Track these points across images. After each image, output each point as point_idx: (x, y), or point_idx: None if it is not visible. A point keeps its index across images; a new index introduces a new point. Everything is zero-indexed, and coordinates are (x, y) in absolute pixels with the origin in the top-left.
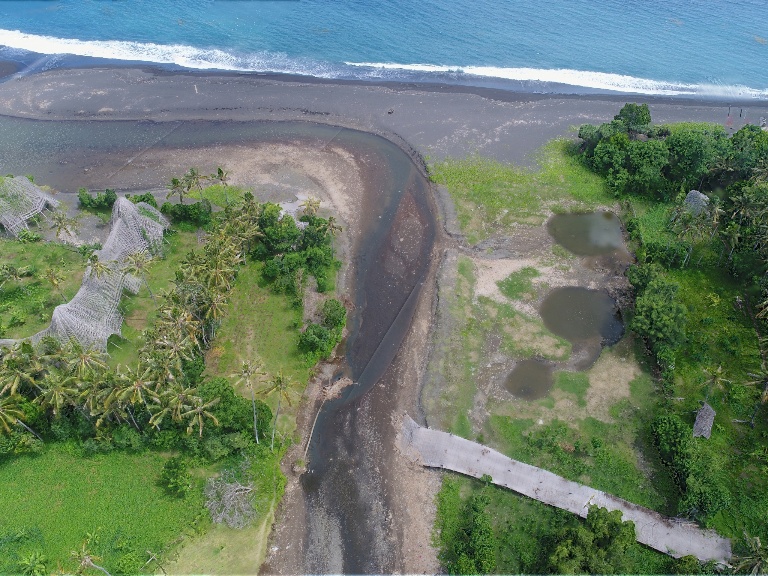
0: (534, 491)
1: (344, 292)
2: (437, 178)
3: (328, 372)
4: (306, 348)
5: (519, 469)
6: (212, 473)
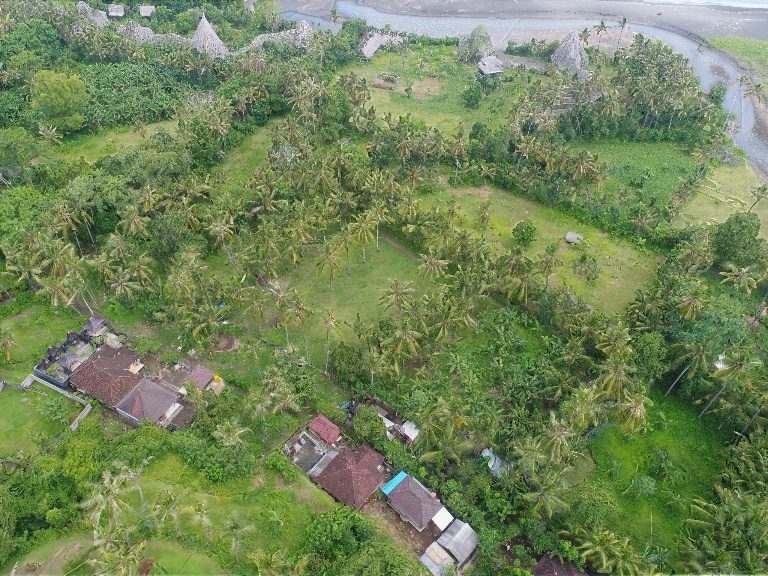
0: None
1: None
2: (716, 45)
3: None
4: None
5: None
6: (702, 150)
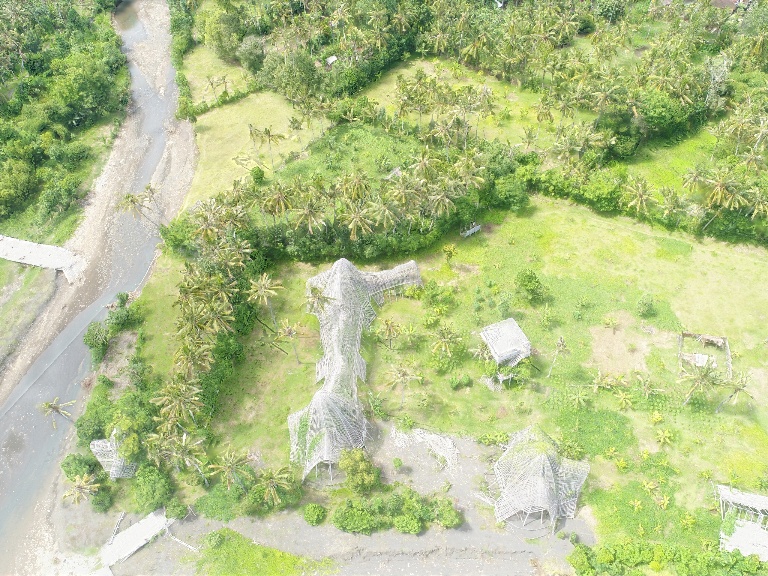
0: (4, 240)
1: (87, 398)
2: None
3: None
4: None
5: (5, 250)
6: None
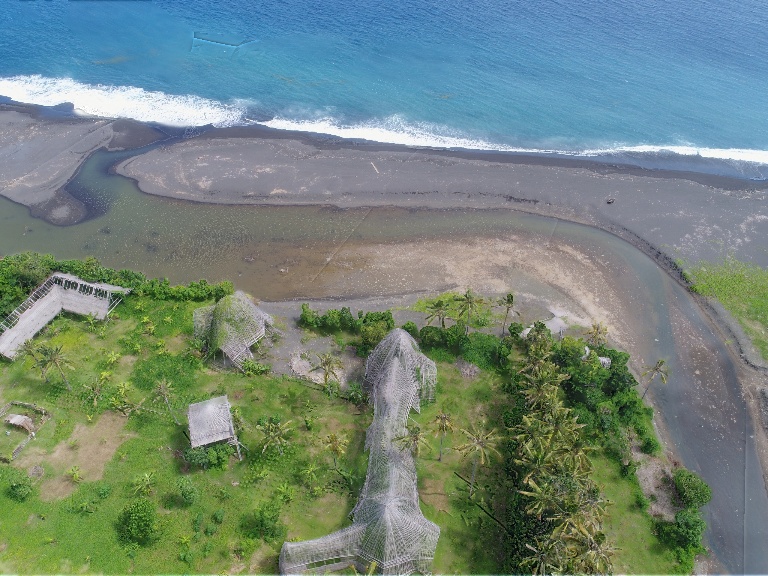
0: None
1: (666, 449)
2: (703, 289)
3: (701, 573)
4: (672, 542)
5: None
6: None
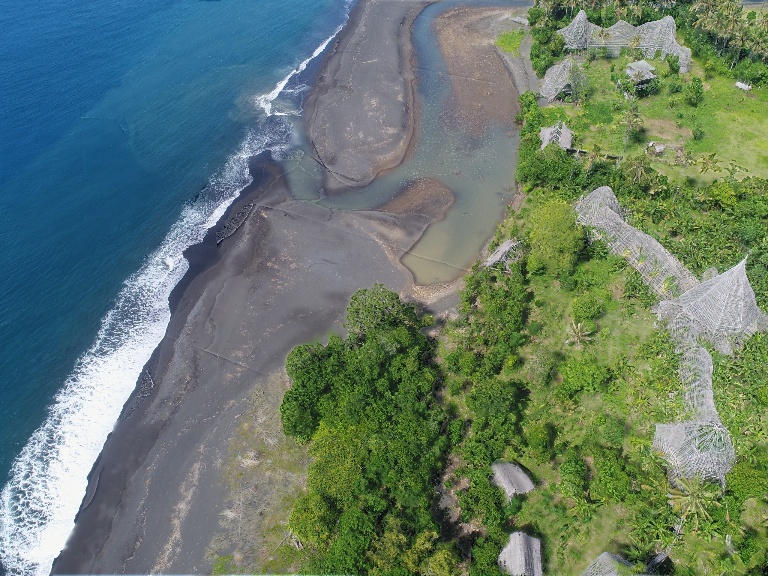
0: None
1: None
2: None
3: None
4: None
5: None
6: None
